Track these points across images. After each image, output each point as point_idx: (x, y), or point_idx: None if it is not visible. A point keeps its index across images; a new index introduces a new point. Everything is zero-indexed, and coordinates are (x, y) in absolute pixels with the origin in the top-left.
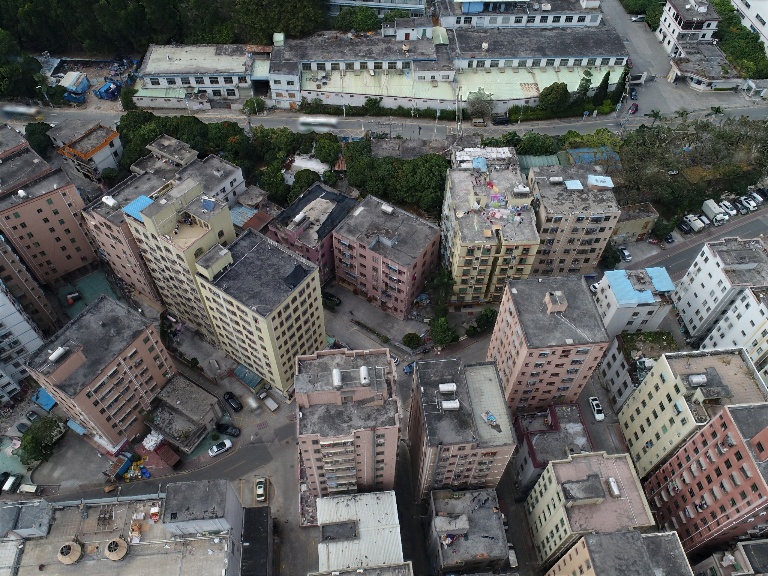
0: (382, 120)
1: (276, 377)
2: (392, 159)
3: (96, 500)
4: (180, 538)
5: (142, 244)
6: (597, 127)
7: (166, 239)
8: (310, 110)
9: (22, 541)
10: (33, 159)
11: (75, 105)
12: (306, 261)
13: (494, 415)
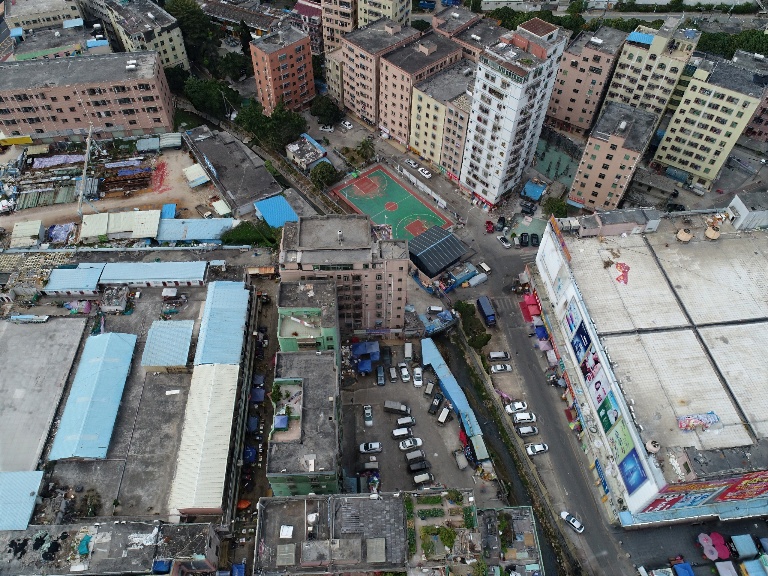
0: (684, 14)
1: (717, 165)
2: (726, 33)
3: (677, 212)
4: (743, 231)
5: (624, 69)
6: None
7: (668, 56)
8: (625, 8)
9: (642, 234)
10: (488, 27)
11: (428, 11)
12: (761, 71)
13: None
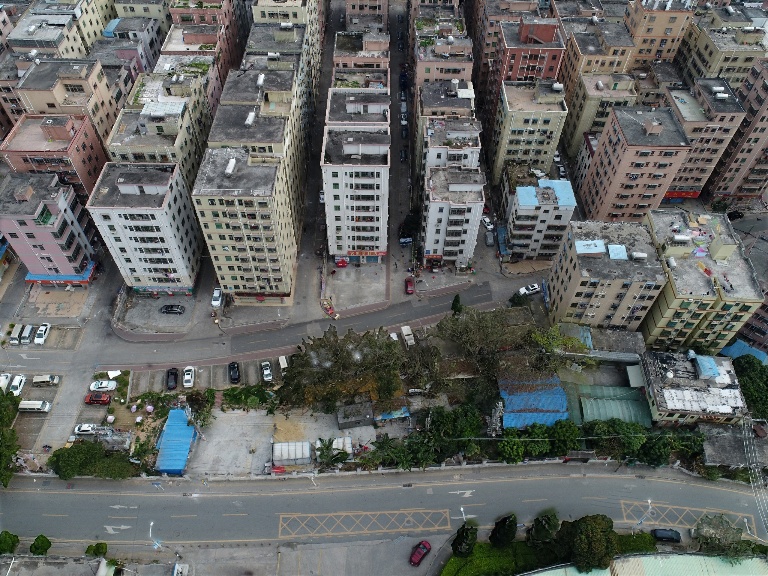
0: None
1: None
2: None
3: None
4: None
5: None
6: (496, 511)
7: None
8: None
9: None
10: None
11: None
12: None
13: (680, 102)
